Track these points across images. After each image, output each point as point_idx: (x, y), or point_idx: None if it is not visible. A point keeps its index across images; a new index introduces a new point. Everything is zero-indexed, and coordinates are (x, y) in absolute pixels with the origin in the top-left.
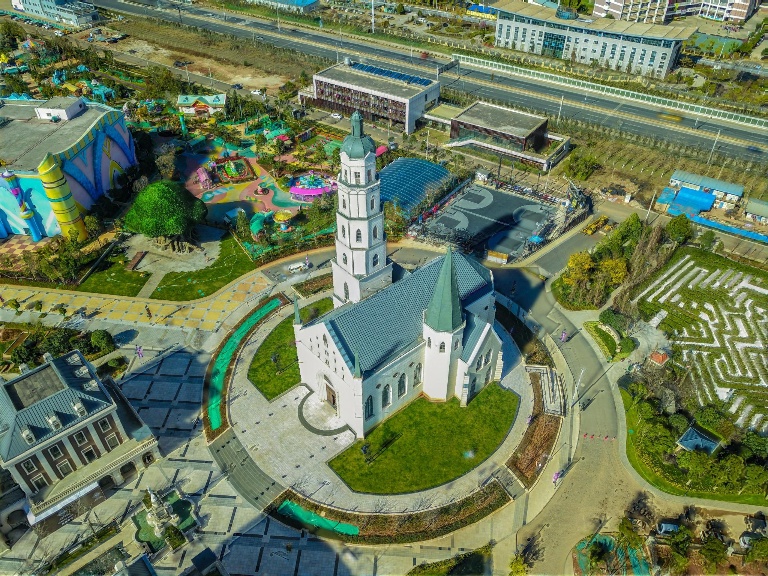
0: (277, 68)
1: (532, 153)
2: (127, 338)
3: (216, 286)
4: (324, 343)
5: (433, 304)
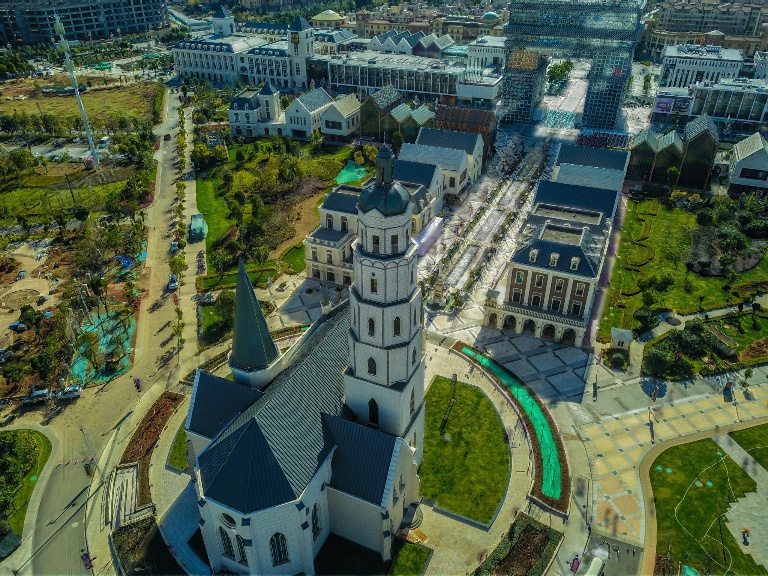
0: None
1: None
2: (651, 387)
3: (662, 487)
4: None
5: None
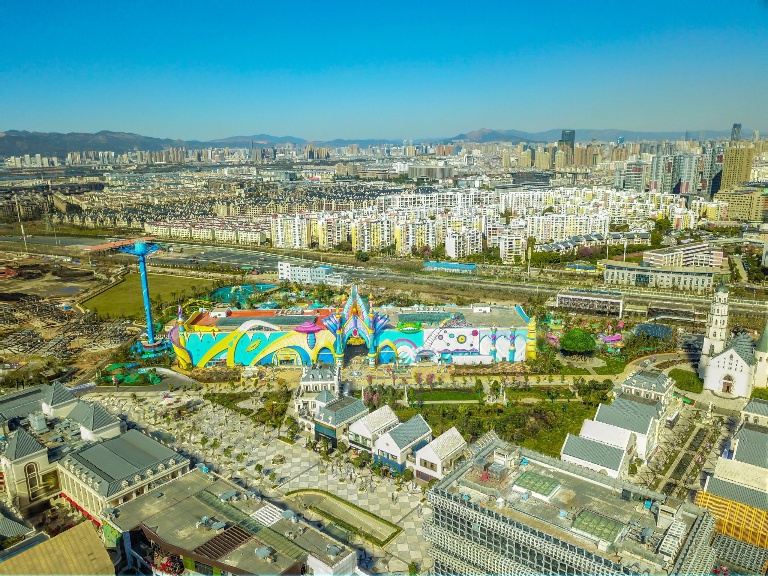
0: (504, 297)
1: None
2: None
3: (621, 369)
4: (730, 359)
5: (762, 342)
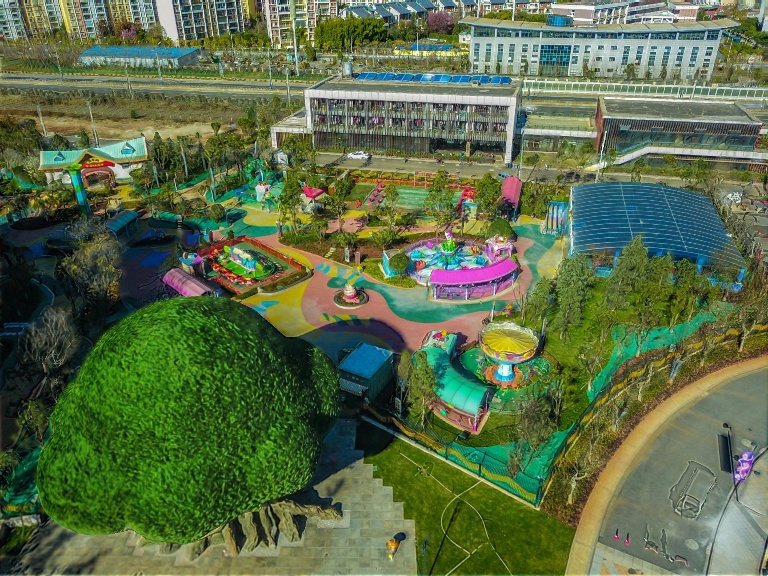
0: (192, 115)
1: None
2: None
3: None
4: None
5: None
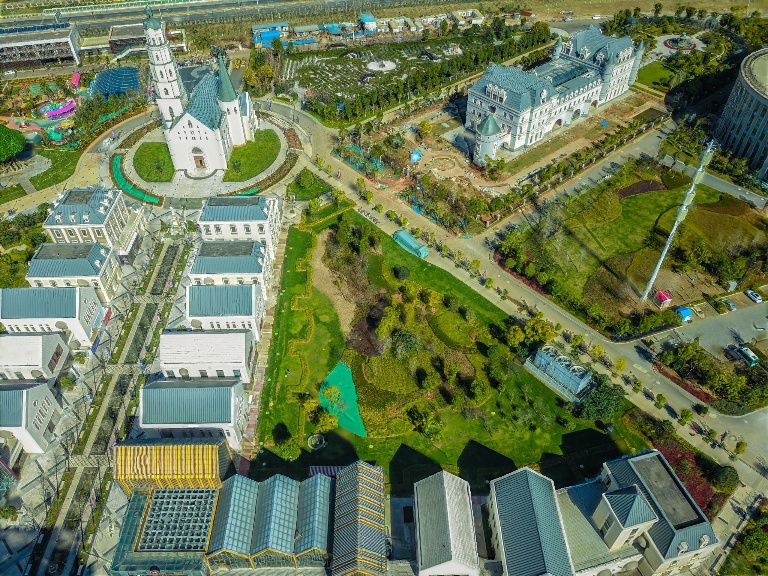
0: None
1: (173, 43)
2: None
3: (71, 168)
4: (189, 127)
5: (223, 89)
